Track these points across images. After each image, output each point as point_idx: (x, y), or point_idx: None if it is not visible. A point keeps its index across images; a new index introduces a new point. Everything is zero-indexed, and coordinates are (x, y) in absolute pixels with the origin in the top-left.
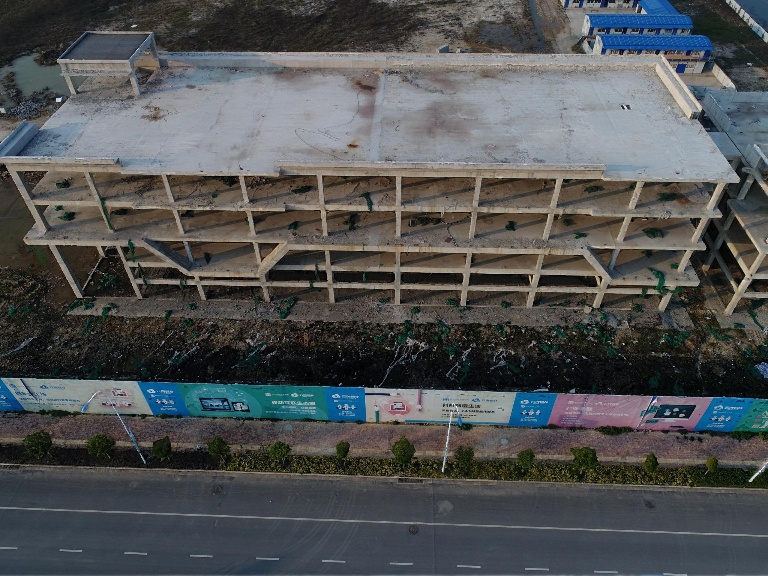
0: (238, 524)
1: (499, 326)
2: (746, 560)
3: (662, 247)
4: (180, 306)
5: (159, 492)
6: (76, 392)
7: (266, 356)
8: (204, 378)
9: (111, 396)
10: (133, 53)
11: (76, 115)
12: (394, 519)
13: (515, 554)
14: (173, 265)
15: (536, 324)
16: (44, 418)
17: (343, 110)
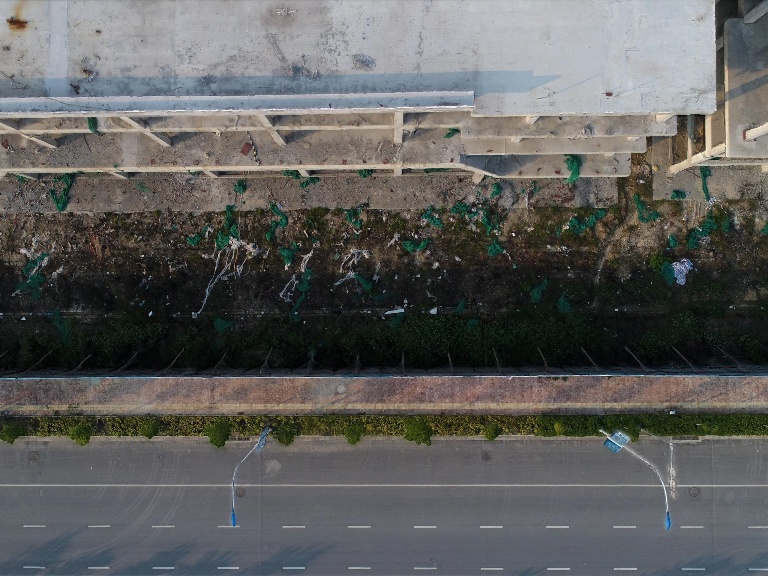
0: (63, 493)
1: (352, 212)
2: (565, 511)
3: (577, 152)
4: None
5: None
6: None
7: (51, 275)
8: None
9: None
10: None
11: None
12: (220, 482)
13: (340, 513)
14: None
15: (403, 206)
16: None
17: None
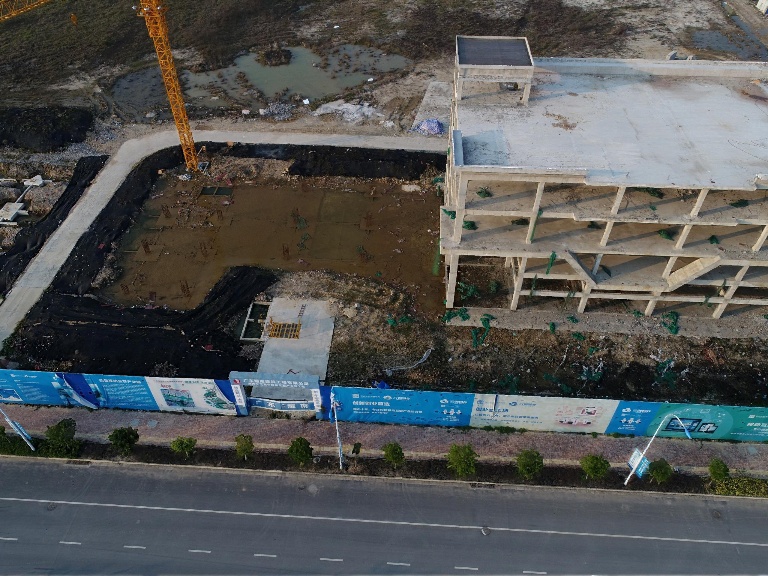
0: (762, 552)
1: None
2: None
3: None
4: (559, 319)
5: (657, 516)
6: (543, 409)
7: (681, 373)
8: (629, 395)
9: (577, 414)
10: (527, 59)
11: (482, 122)
12: None
13: None
14: (584, 278)
15: None
16: (491, 434)
17: (757, 121)
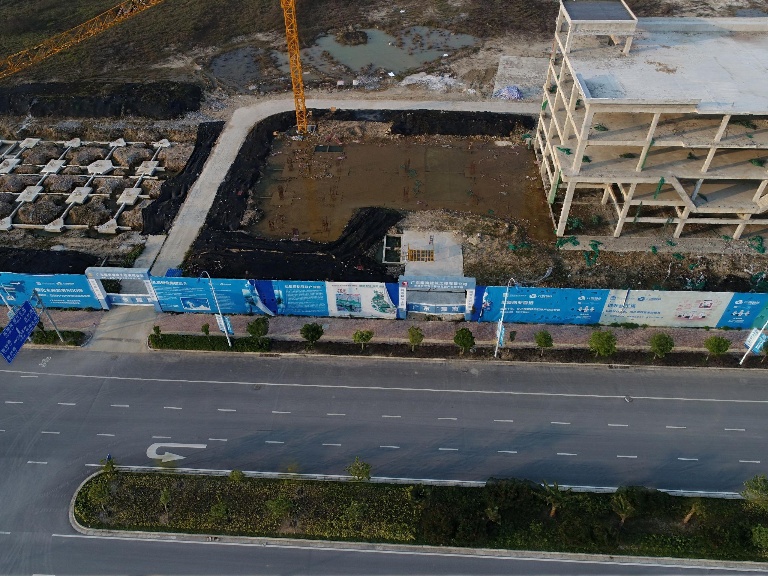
0: None
1: None
2: None
3: None
4: (659, 243)
5: None
6: (666, 304)
7: None
8: None
9: (695, 308)
10: (629, 15)
11: (594, 69)
12: None
13: None
14: (686, 201)
15: None
16: (618, 330)
17: None
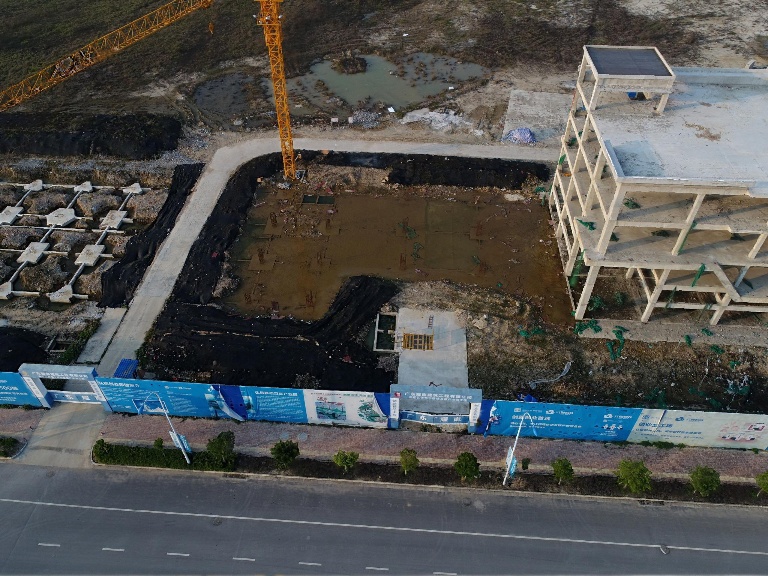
0: None
1: None
2: None
3: None
4: (693, 331)
5: None
6: (709, 425)
7: None
8: None
9: (743, 430)
10: (664, 69)
11: (624, 132)
12: None
13: None
14: (729, 290)
15: None
16: (650, 450)
17: None
